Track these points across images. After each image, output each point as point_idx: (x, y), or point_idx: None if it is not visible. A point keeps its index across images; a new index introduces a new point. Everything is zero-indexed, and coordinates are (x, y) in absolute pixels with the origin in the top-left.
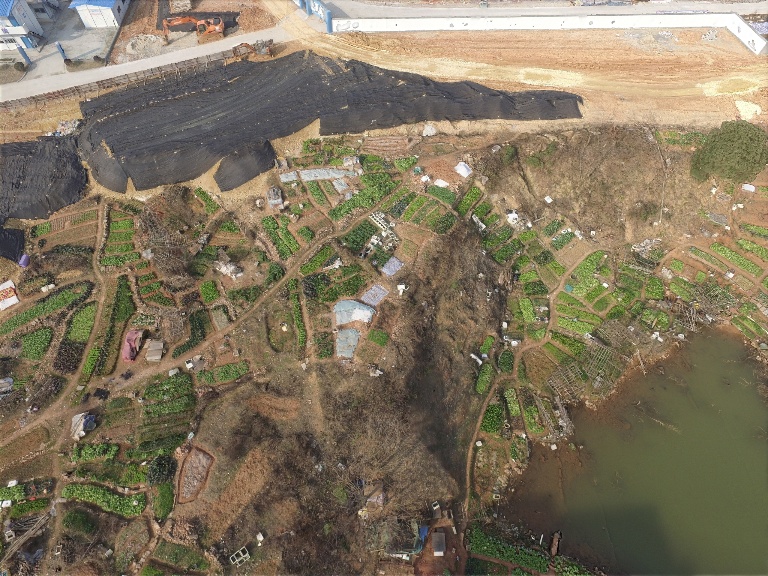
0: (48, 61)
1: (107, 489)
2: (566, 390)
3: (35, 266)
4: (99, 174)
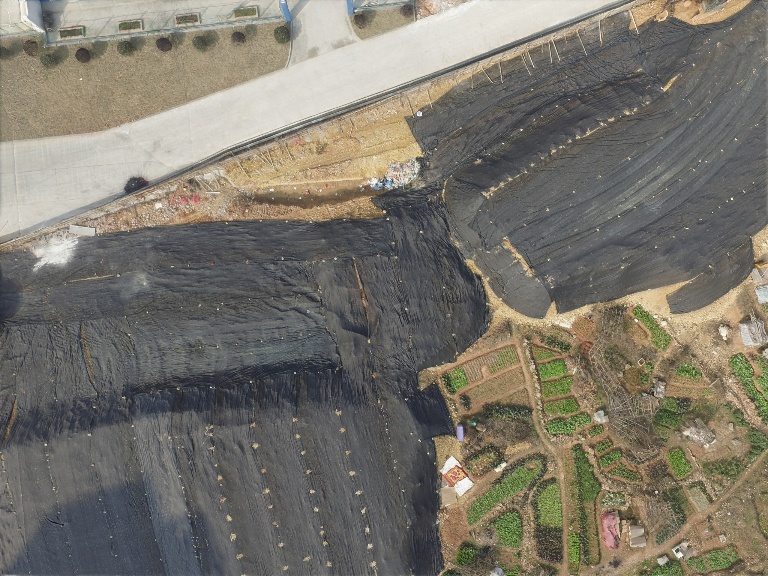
0: (316, 11)
1: None
2: None
3: (478, 442)
4: (505, 291)
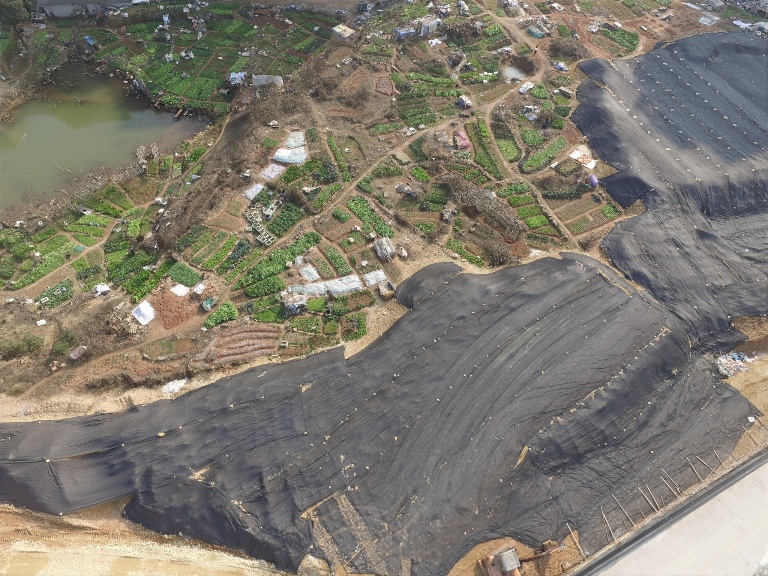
0: None
1: (432, 82)
2: (131, 167)
3: (579, 175)
4: None
